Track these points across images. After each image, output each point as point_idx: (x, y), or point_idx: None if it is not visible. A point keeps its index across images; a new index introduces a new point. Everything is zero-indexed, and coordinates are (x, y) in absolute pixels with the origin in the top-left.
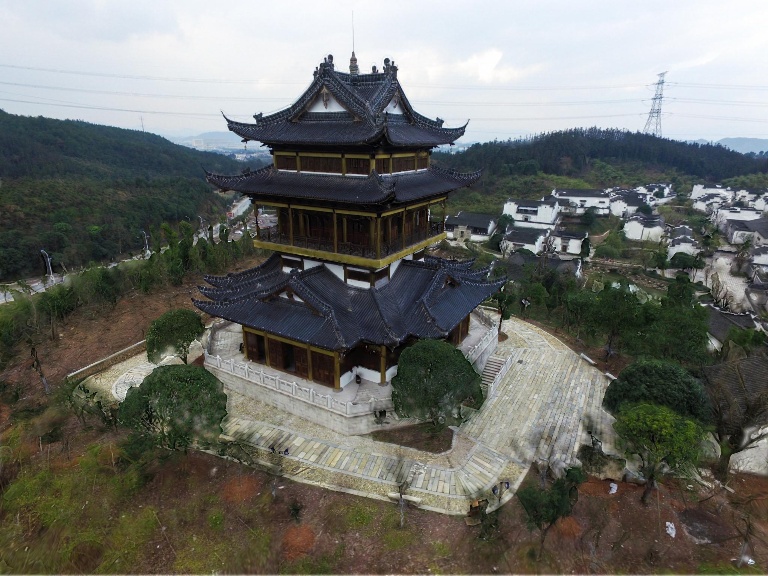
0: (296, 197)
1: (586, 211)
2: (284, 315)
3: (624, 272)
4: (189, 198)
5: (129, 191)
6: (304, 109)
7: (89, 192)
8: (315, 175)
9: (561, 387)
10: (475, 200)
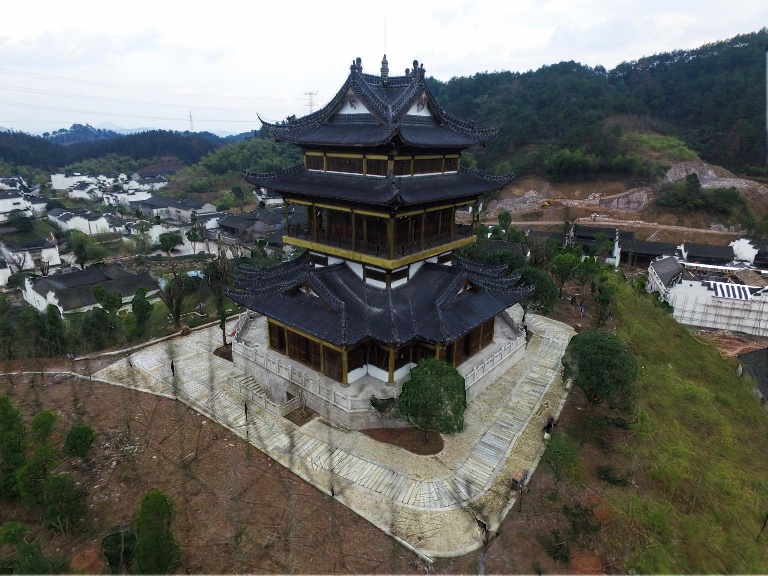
0: (456, 197)
1: (9, 217)
2: (470, 307)
3: (128, 265)
4: None
5: None
6: None
7: None
8: (427, 177)
9: None
10: None
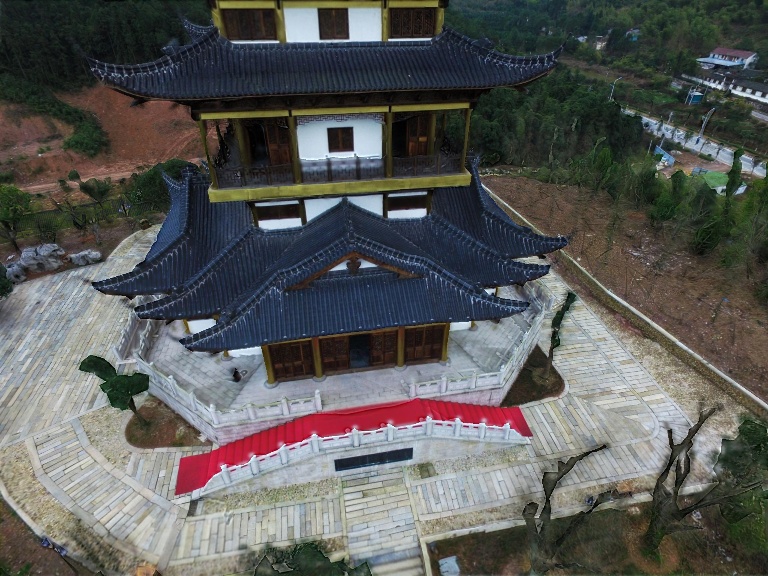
0: None
1: None
2: None
3: None
4: None
5: None
6: None
7: None
8: None
9: (49, 348)
10: None
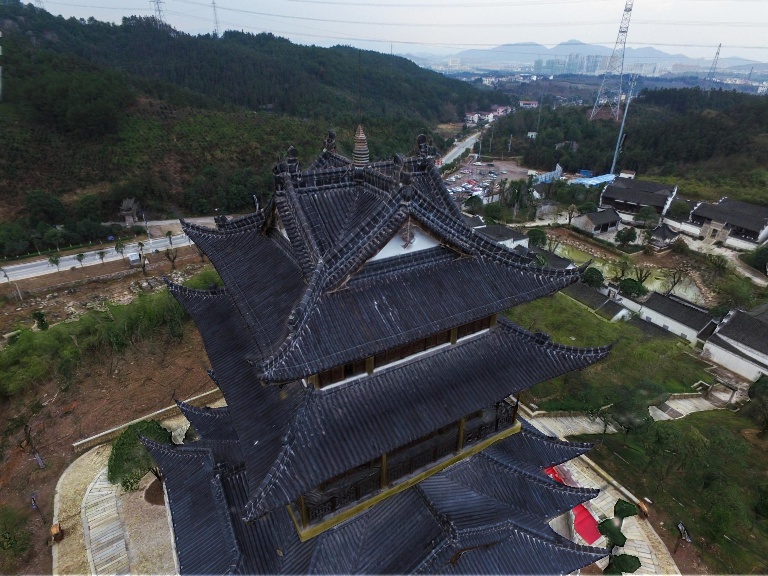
0: None
1: None
2: (205, 515)
3: None
4: (404, 140)
5: (353, 130)
6: (266, 225)
7: (316, 131)
8: None
9: None
10: (757, 181)
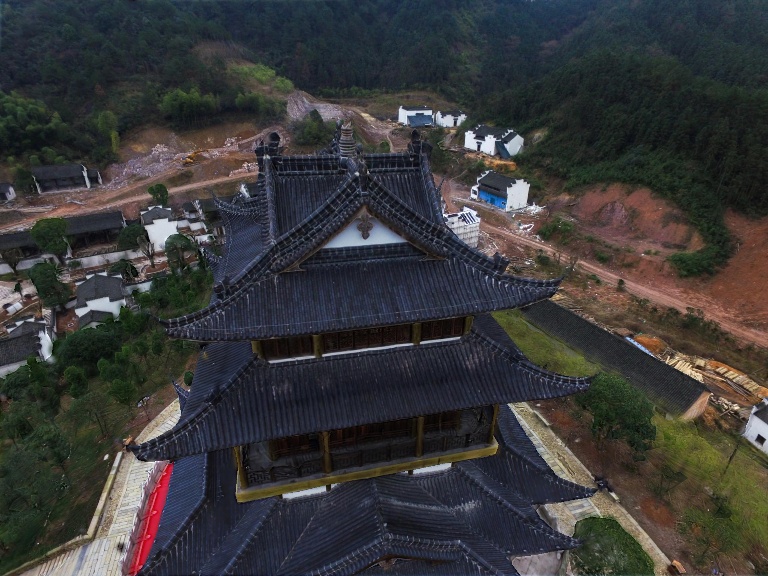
0: None
1: None
2: None
3: None
4: None
5: None
6: None
7: None
8: None
9: None
10: None
